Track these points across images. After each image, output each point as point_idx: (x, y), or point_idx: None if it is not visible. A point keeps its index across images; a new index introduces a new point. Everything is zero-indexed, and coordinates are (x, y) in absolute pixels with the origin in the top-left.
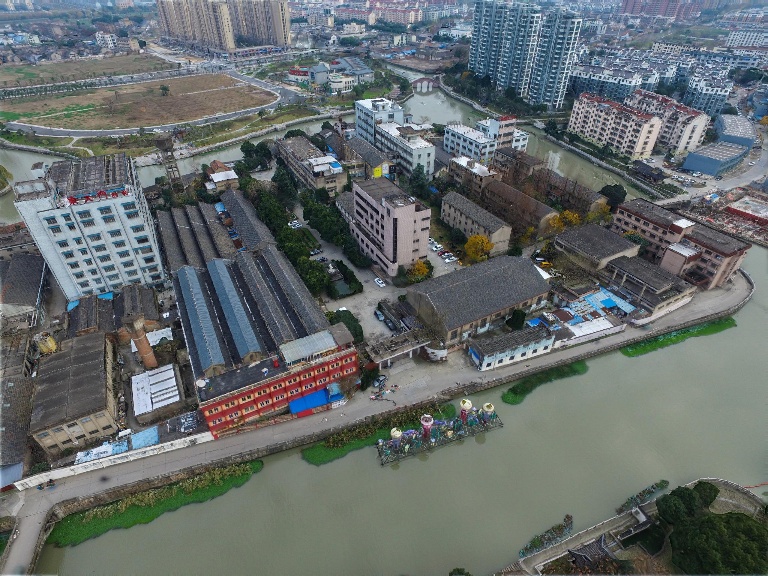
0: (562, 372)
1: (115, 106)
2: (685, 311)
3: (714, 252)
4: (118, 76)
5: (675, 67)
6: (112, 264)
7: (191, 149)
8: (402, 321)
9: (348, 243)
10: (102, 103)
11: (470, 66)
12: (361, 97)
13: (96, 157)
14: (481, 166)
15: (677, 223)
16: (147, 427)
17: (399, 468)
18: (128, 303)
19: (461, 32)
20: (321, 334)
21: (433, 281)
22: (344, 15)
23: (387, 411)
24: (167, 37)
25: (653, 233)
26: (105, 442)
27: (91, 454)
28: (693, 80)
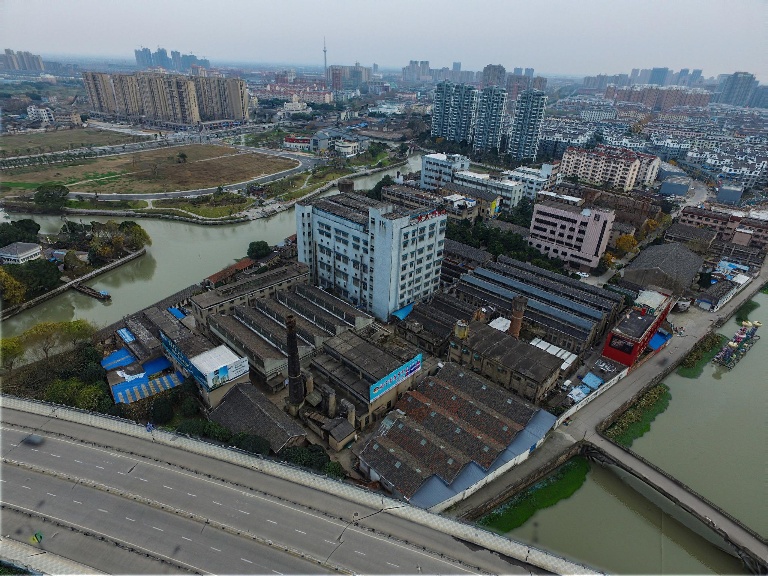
0: (750, 307)
1: (142, 173)
2: (766, 267)
3: (765, 229)
4: (96, 147)
5: (591, 132)
6: (420, 276)
7: (283, 203)
8: (643, 290)
9: (538, 251)
10: (122, 171)
11: (434, 134)
12: (376, 158)
13: (335, 196)
14: (565, 195)
15: (734, 215)
16: (569, 379)
17: (722, 377)
18: (457, 303)
19: (389, 110)
20: (648, 292)
21: (638, 263)
22: (264, 96)
23: (699, 340)
24: (99, 112)
25: (714, 225)
26: (572, 387)
27: (573, 396)
28: (612, 139)
